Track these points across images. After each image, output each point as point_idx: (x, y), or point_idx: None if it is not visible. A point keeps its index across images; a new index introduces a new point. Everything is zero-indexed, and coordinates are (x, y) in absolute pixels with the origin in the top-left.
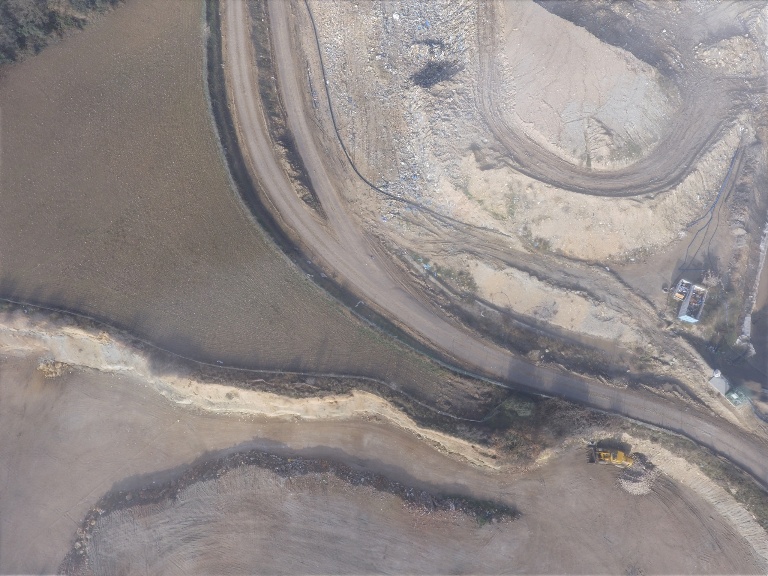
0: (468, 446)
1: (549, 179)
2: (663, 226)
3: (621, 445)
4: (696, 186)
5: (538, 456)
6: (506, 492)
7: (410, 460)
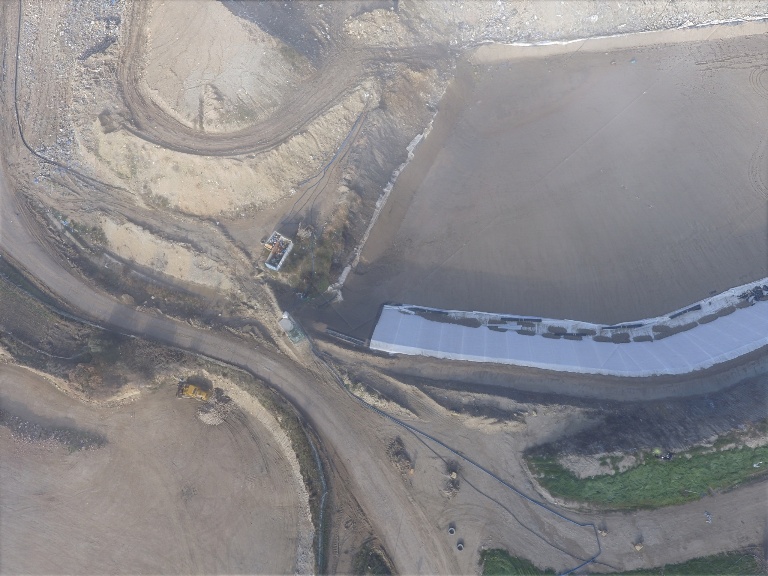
0: (63, 381)
1: (161, 141)
2: (270, 184)
3: (205, 381)
4: (308, 147)
5: (121, 390)
6: (102, 424)
7: (33, 397)
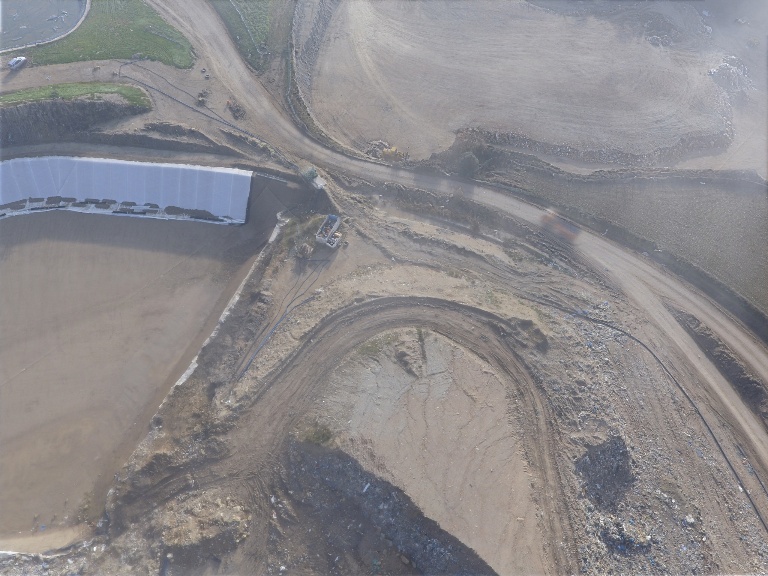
0: None
1: (461, 312)
2: None
3: None
4: (300, 329)
5: None
6: None
7: None
